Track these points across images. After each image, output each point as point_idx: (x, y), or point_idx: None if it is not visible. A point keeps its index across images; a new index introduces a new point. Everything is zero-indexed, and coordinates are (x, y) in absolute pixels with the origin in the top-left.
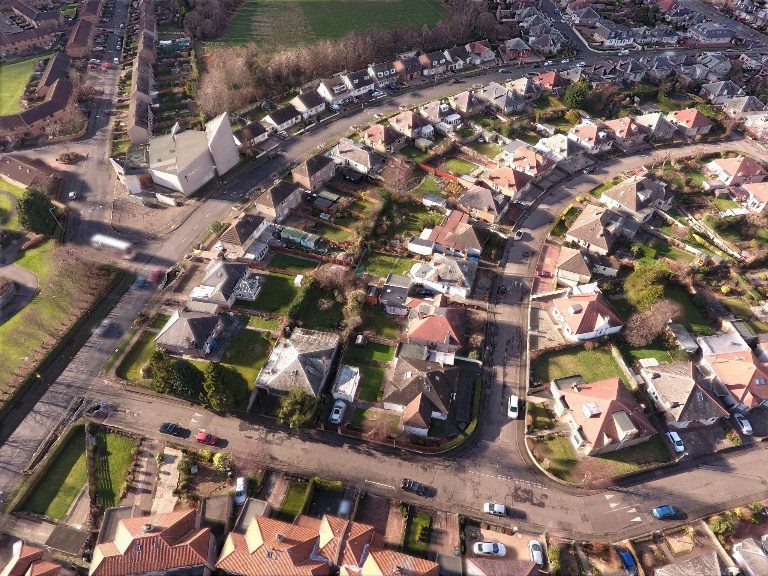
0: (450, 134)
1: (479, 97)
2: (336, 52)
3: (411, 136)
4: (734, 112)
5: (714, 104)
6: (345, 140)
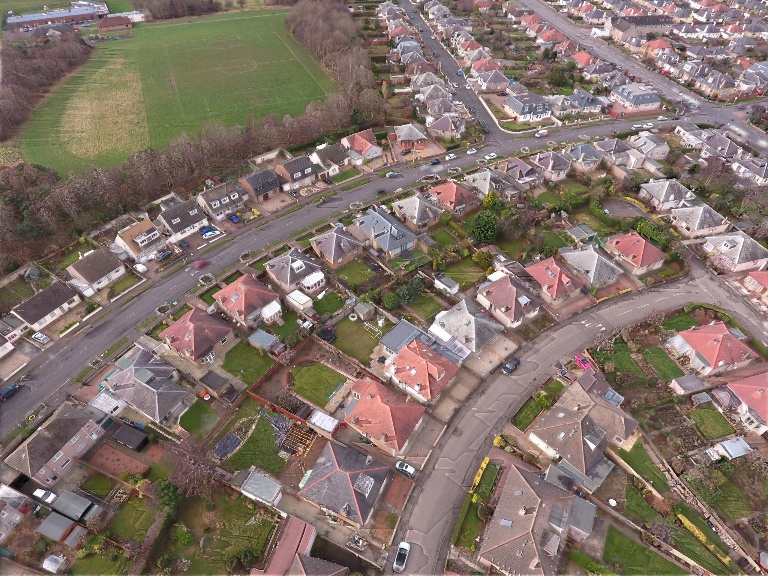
0: (305, 315)
1: (354, 233)
2: (154, 170)
3: (245, 324)
4: (687, 228)
5: (659, 212)
6: (123, 364)
